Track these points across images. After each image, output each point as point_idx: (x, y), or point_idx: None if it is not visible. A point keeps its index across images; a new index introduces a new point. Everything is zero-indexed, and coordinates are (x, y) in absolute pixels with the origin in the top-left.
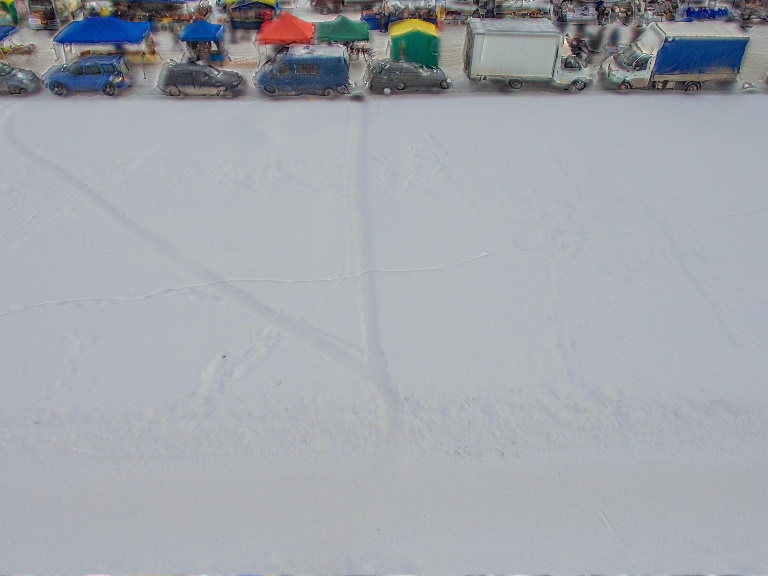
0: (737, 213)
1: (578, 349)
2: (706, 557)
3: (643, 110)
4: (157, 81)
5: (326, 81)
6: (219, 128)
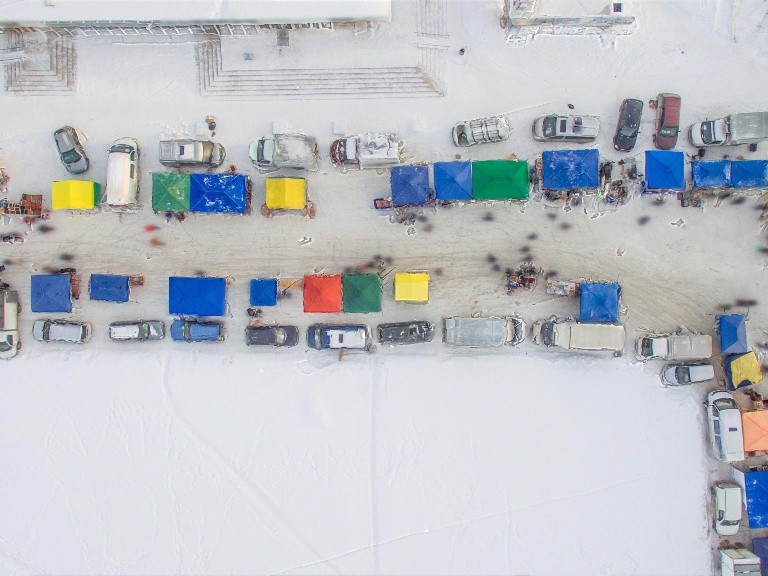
0: (544, 502)
1: None
2: None
3: (543, 378)
4: (247, 342)
5: None
6: (298, 412)
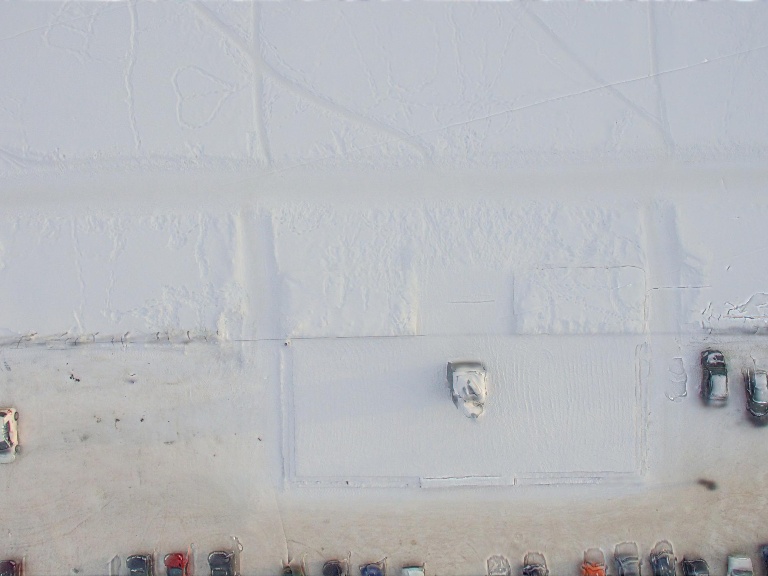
0: None
1: (731, 120)
2: (744, 191)
3: None
4: None
5: None
6: None
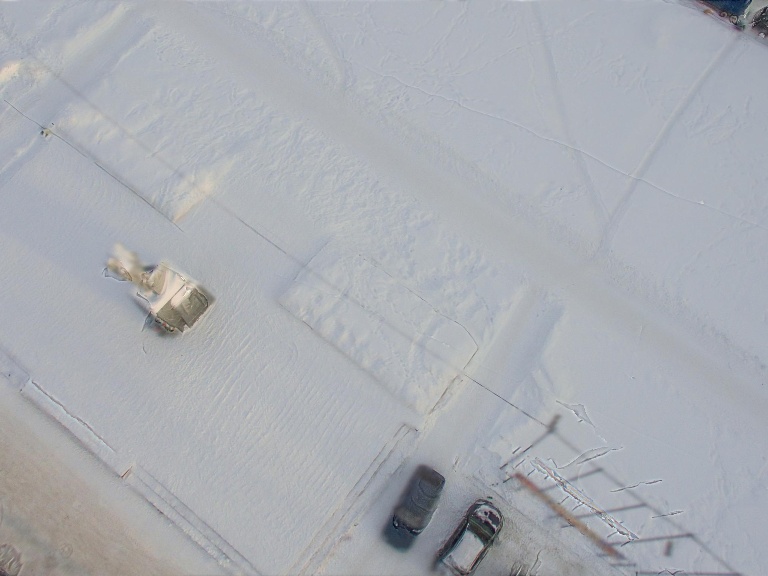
0: None
1: (693, 273)
2: (661, 357)
3: None
4: None
5: (728, 7)
6: (636, 23)
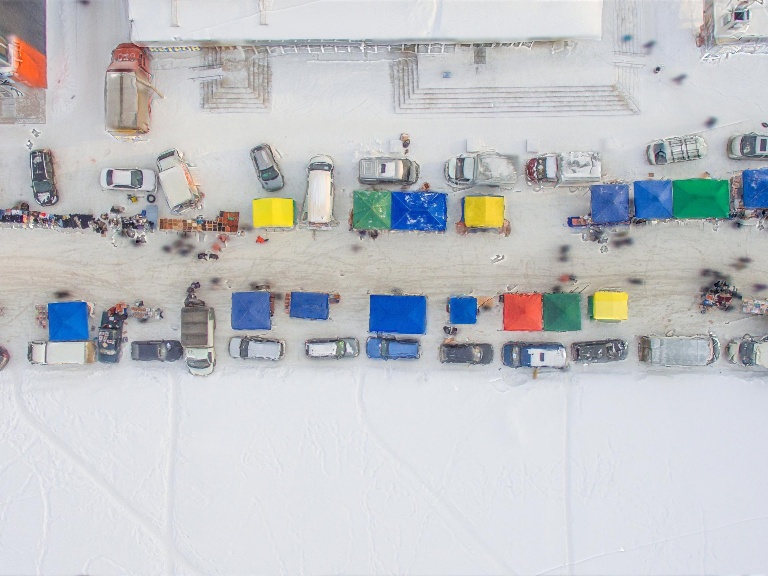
0: (739, 522)
1: None
2: None
3: (737, 396)
4: (442, 360)
5: None
6: (494, 430)
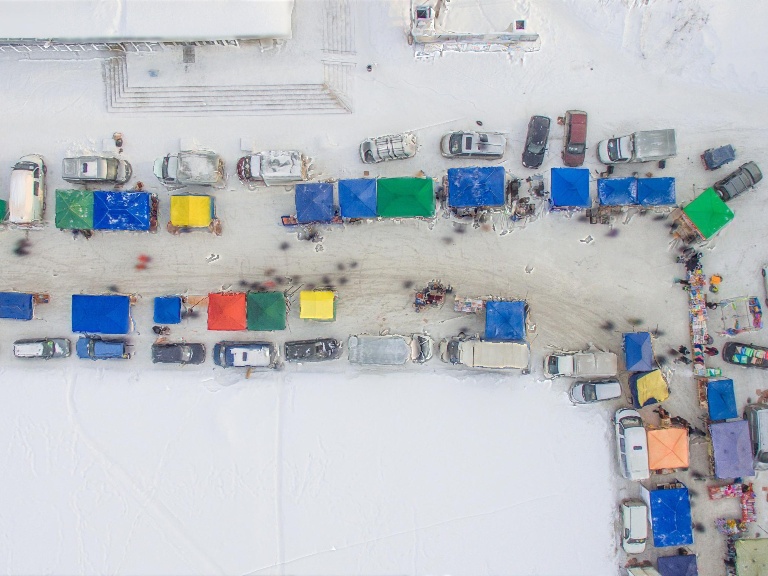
0: (451, 520)
1: None
2: None
3: (452, 395)
4: (153, 360)
5: None
6: (205, 430)
